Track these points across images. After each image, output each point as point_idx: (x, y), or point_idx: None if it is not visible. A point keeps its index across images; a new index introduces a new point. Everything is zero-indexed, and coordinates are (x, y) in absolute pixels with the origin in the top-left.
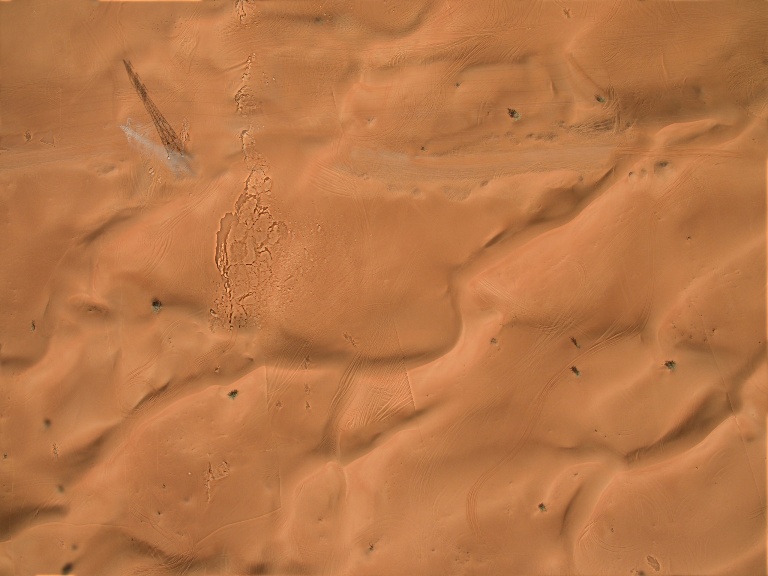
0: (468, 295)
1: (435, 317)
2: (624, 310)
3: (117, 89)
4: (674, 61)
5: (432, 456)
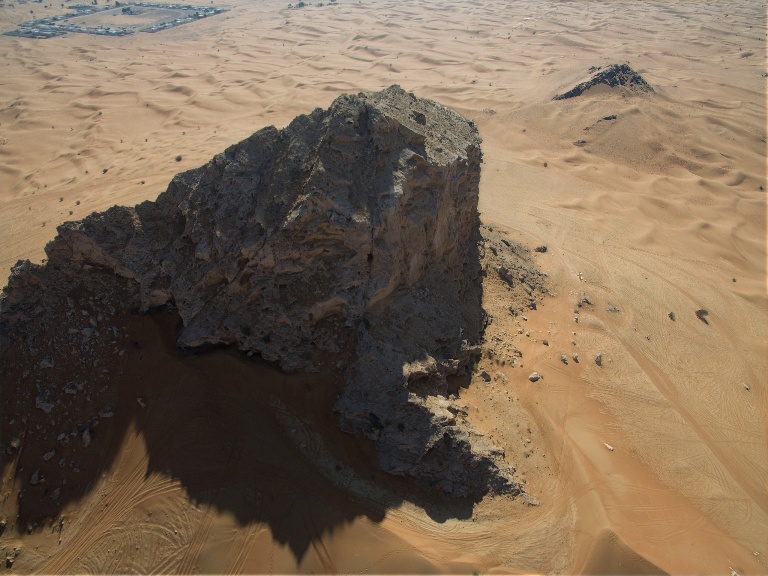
0: None
1: None
2: (767, 8)
3: None
4: None
5: None
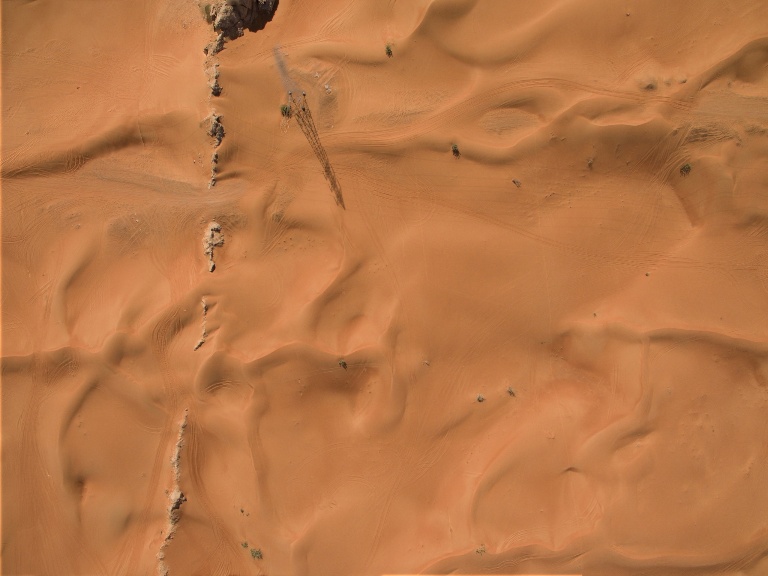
0: None
1: None
2: None
3: (356, 180)
4: None
5: None
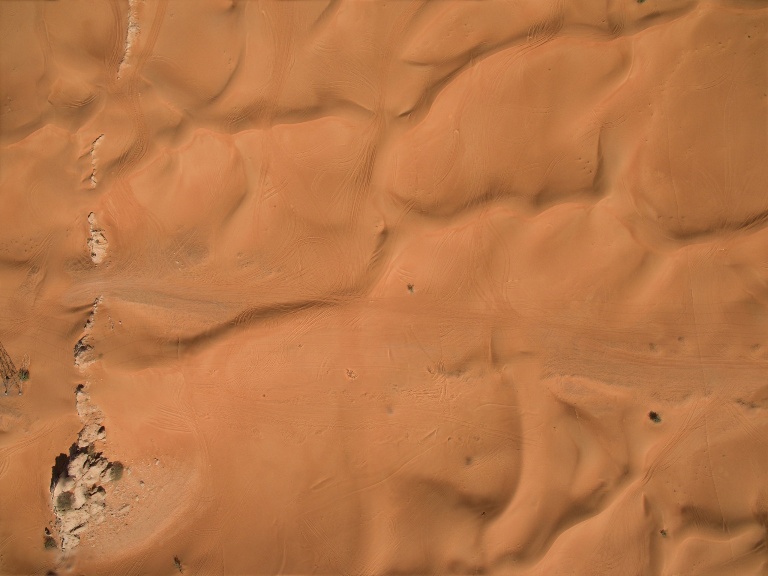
0: (293, 531)
1: (260, 549)
2: (420, 570)
3: None
4: (499, 347)
5: None
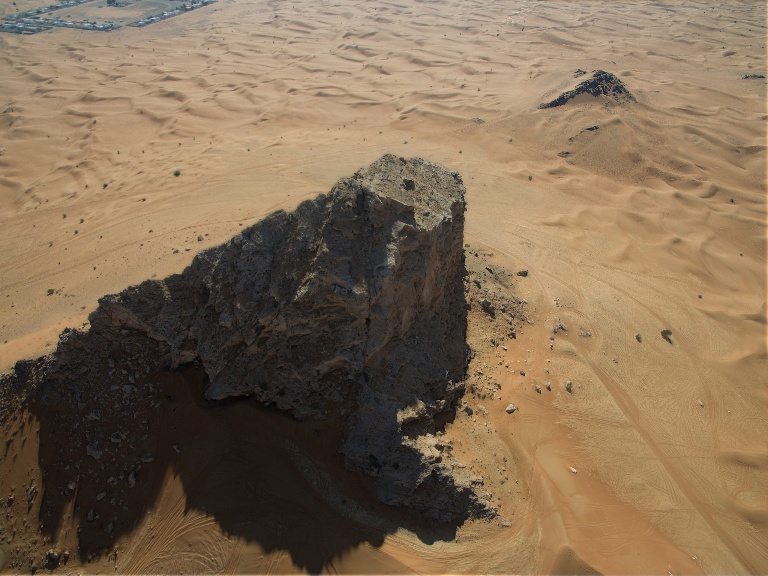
0: None
1: None
2: (754, 0)
3: None
4: None
5: None
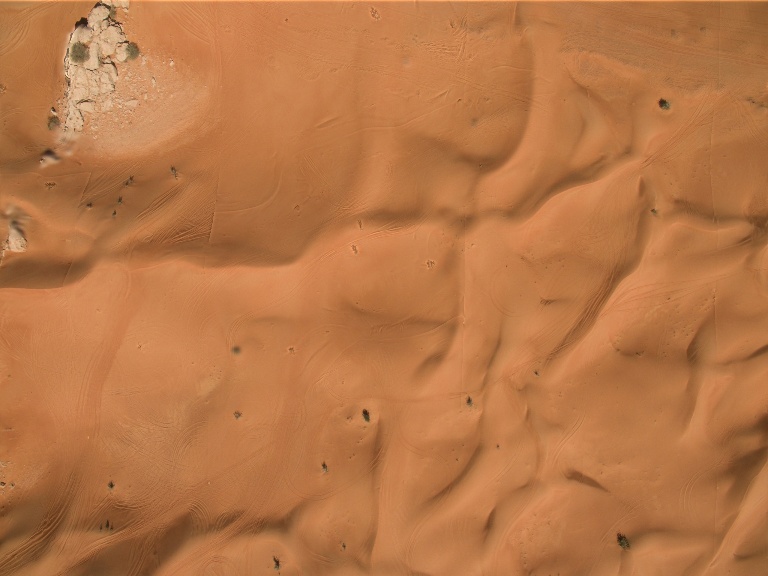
0: (291, 165)
1: (256, 175)
2: (410, 210)
3: None
4: (524, 10)
5: (210, 283)
